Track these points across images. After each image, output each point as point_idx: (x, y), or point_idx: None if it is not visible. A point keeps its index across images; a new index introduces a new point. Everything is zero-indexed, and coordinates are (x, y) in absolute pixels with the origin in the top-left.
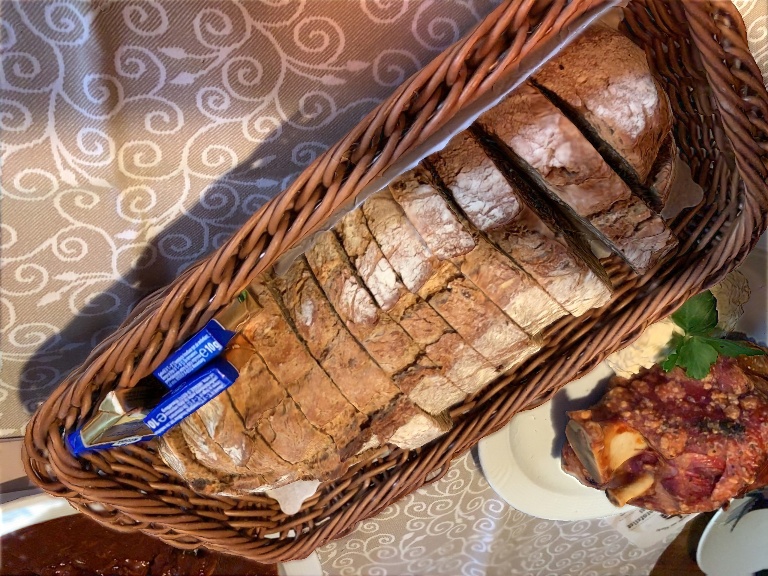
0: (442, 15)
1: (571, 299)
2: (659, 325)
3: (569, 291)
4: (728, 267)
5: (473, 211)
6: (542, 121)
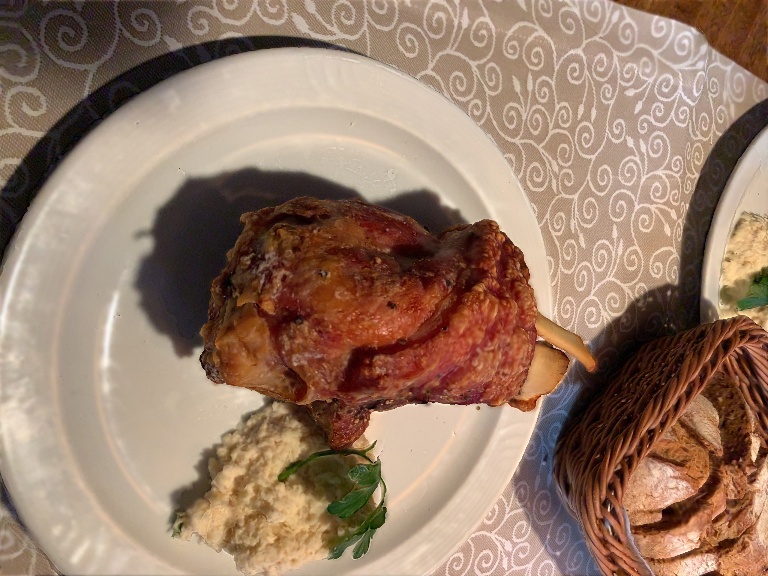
0: (555, 538)
1: (766, 489)
2: (767, 325)
3: (762, 496)
4: (766, 343)
5: (703, 572)
6: (667, 542)
